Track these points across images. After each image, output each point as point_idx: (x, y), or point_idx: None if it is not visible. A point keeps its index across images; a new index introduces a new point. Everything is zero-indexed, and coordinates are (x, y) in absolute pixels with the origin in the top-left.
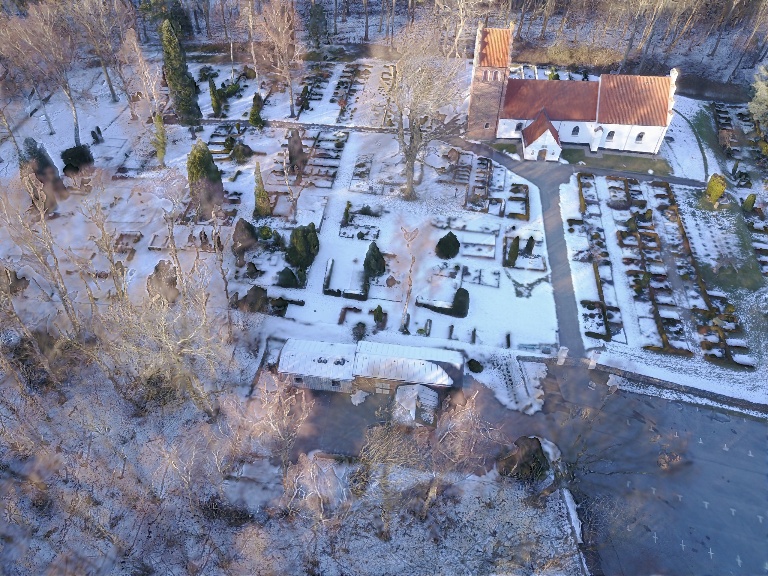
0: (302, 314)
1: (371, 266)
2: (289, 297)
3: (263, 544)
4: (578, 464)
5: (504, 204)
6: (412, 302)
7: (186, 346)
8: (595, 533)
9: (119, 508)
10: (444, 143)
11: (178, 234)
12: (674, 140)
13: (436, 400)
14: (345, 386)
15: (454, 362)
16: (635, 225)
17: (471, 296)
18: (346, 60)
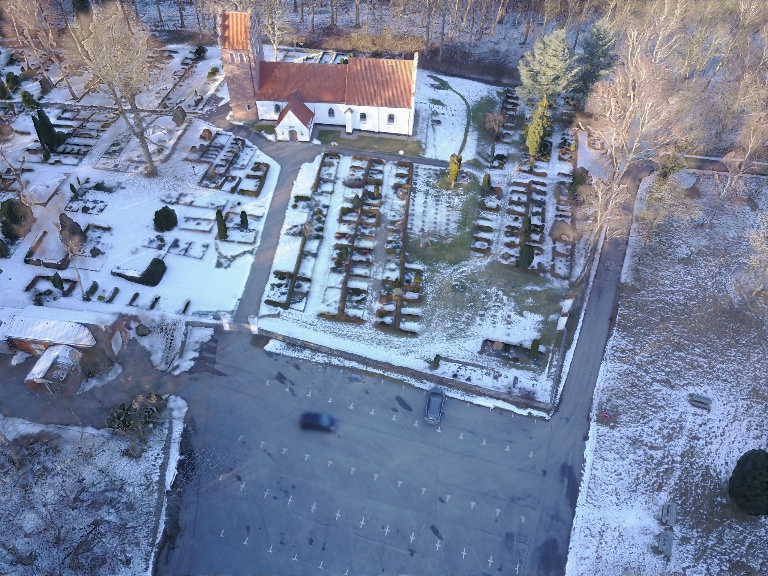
0: None
1: (62, 236)
2: None
3: None
4: (136, 412)
5: (237, 181)
6: (110, 271)
7: None
8: (187, 481)
9: None
10: (209, 124)
11: None
12: (441, 123)
13: None
14: (4, 347)
15: (102, 324)
16: (360, 202)
17: (171, 266)
18: (156, 46)
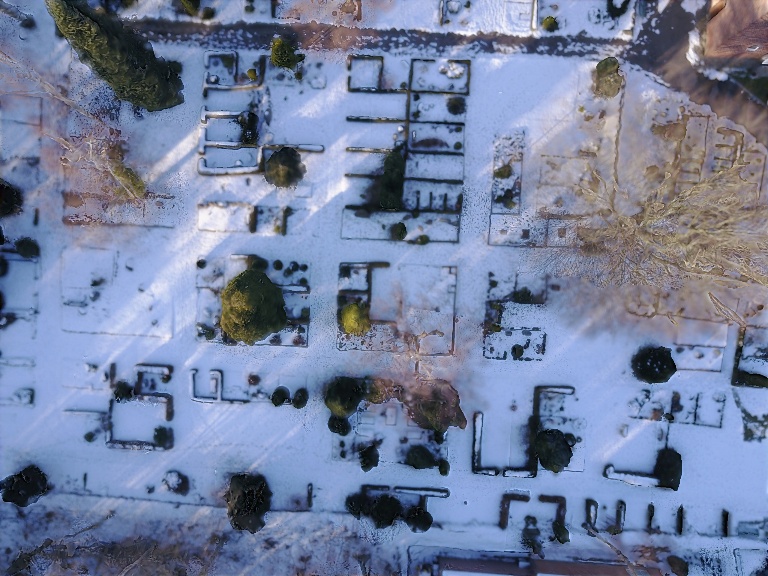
0: (449, 511)
1: None
2: (426, 482)
3: None
4: None
5: None
6: (598, 470)
7: None
8: None
9: None
10: (656, 81)
11: (227, 364)
12: None
13: None
14: None
15: None
16: None
17: (680, 448)
18: None
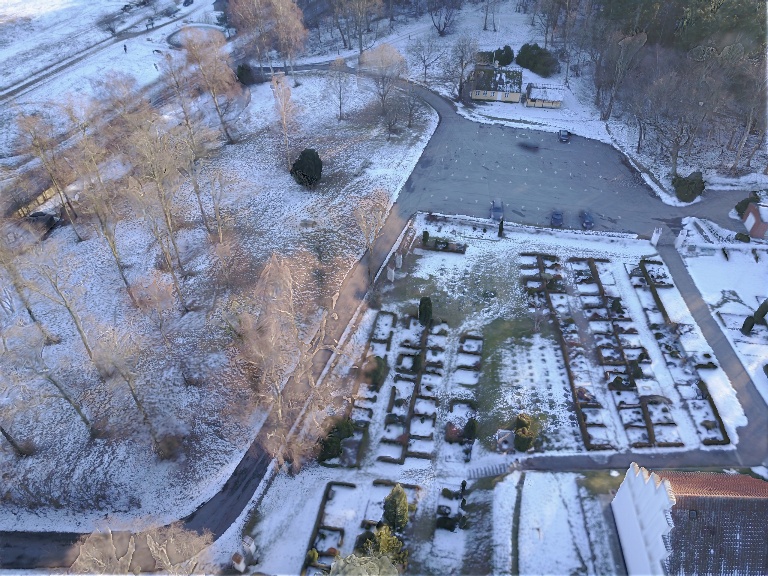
0: None
1: None
2: None
3: None
4: None
5: None
6: None
7: None
8: (634, 176)
9: None
10: None
11: None
12: None
13: None
14: None
15: (766, 208)
16: None
17: None
18: None
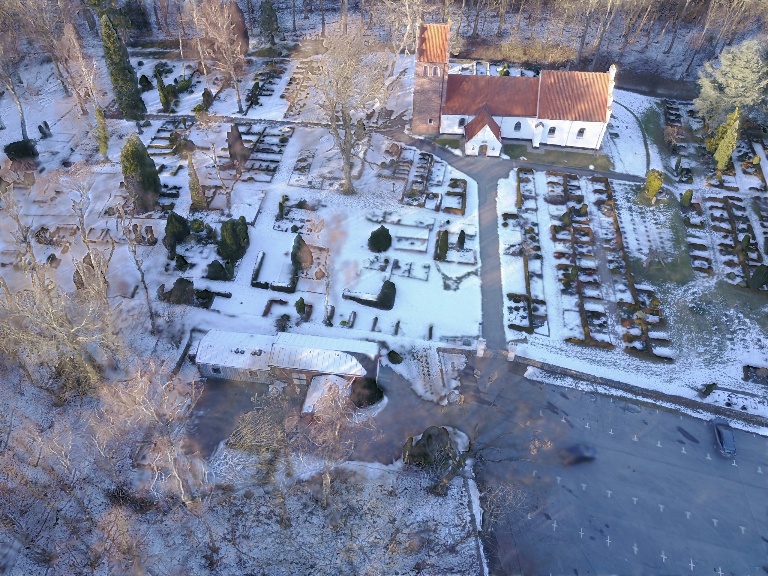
0: (228, 306)
1: (297, 259)
2: (217, 289)
3: (166, 531)
4: (470, 452)
5: (440, 198)
6: (339, 295)
7: (81, 334)
8: (495, 521)
9: (31, 495)
10: (388, 138)
11: (114, 227)
12: (619, 136)
13: (349, 390)
14: (262, 376)
15: (369, 353)
16: (570, 220)
17: (399, 289)
18: (301, 56)
